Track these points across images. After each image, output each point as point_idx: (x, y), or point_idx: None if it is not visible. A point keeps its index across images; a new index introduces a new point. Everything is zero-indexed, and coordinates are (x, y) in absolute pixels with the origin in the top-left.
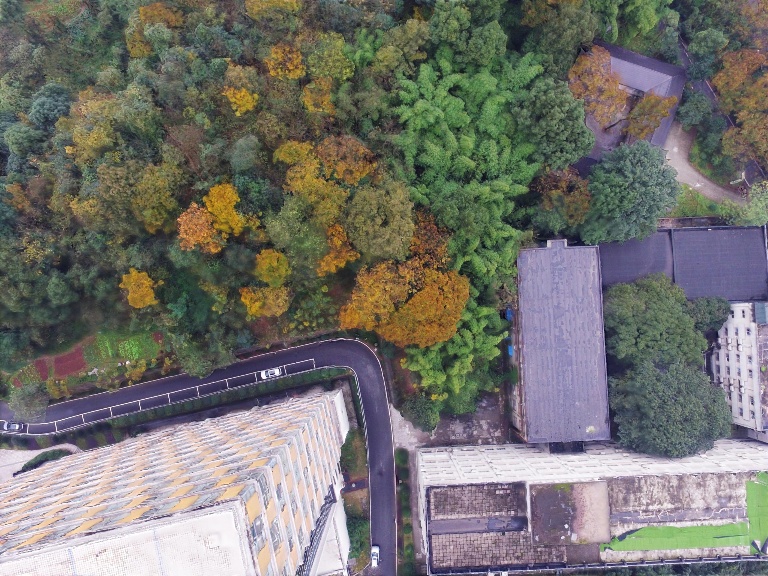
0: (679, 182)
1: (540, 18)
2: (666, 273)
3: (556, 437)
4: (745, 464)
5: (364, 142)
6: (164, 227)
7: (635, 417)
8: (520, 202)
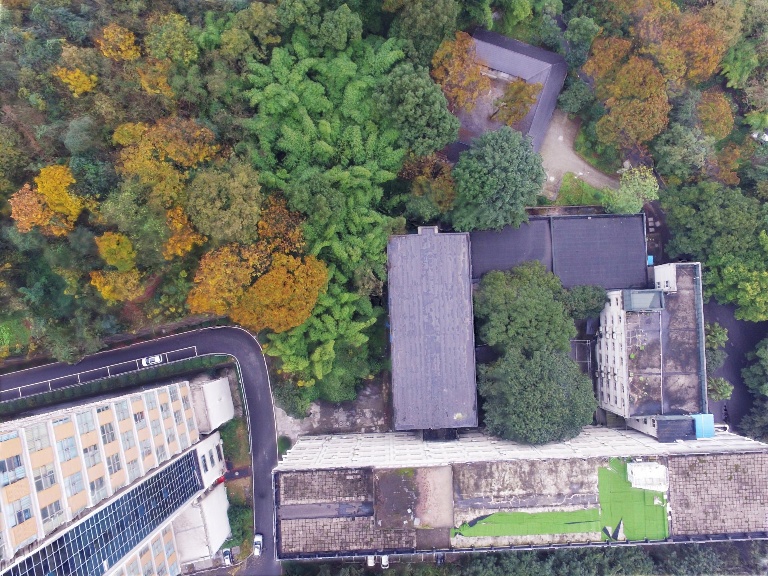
0: (544, 168)
1: (397, 3)
2: (545, 261)
3: (423, 424)
4: (601, 450)
5: (213, 125)
6: (1, 209)
7: (501, 404)
8: (402, 190)
